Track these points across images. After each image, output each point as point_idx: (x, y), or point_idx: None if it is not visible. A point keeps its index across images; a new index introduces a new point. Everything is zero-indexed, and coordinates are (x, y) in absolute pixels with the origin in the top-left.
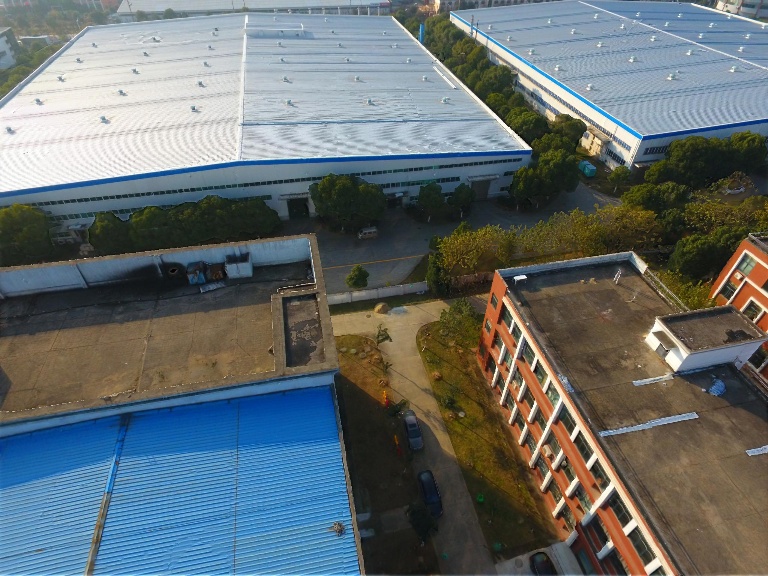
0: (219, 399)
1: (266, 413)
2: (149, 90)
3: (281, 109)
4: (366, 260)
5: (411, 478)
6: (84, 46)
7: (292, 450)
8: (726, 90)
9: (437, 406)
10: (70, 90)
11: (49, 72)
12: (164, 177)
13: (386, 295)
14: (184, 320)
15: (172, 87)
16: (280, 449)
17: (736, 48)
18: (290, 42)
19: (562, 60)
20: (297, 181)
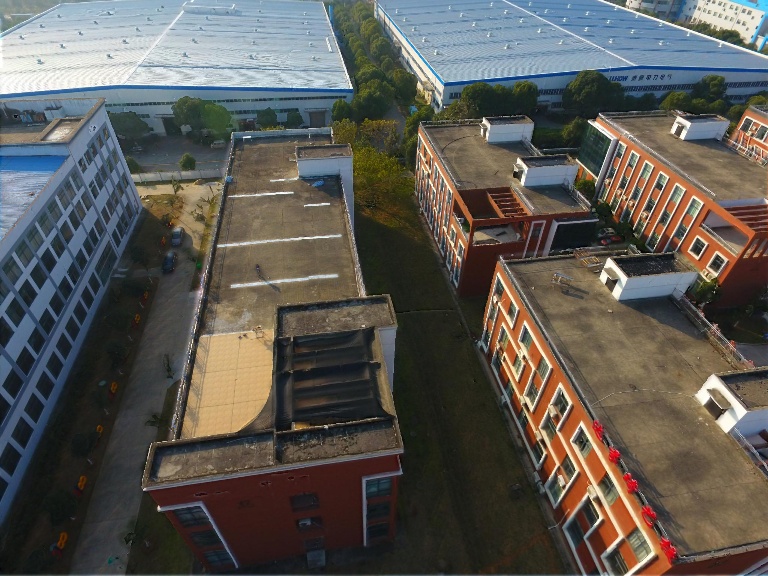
0: (2, 155)
1: (25, 162)
2: (84, 45)
3: (176, 58)
4: (209, 160)
5: (164, 257)
6: (51, 17)
7: (29, 173)
8: (541, 56)
9: (203, 228)
10: (25, 44)
11: (15, 33)
12: (65, 94)
13: (208, 176)
14: (9, 135)
15: (103, 44)
16: (23, 172)
17: (583, 29)
18: (217, 17)
19: (434, 35)
20: (167, 104)
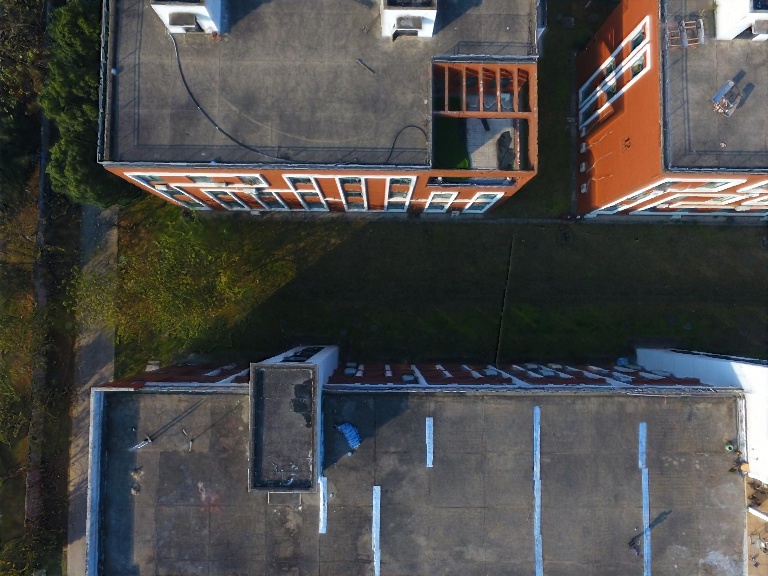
0: None
1: None
2: None
3: None
4: None
5: None
6: None
7: None
8: None
9: None
10: None
11: None
12: None
13: None
14: None
15: None
16: None
17: None
18: None
19: None
20: None
